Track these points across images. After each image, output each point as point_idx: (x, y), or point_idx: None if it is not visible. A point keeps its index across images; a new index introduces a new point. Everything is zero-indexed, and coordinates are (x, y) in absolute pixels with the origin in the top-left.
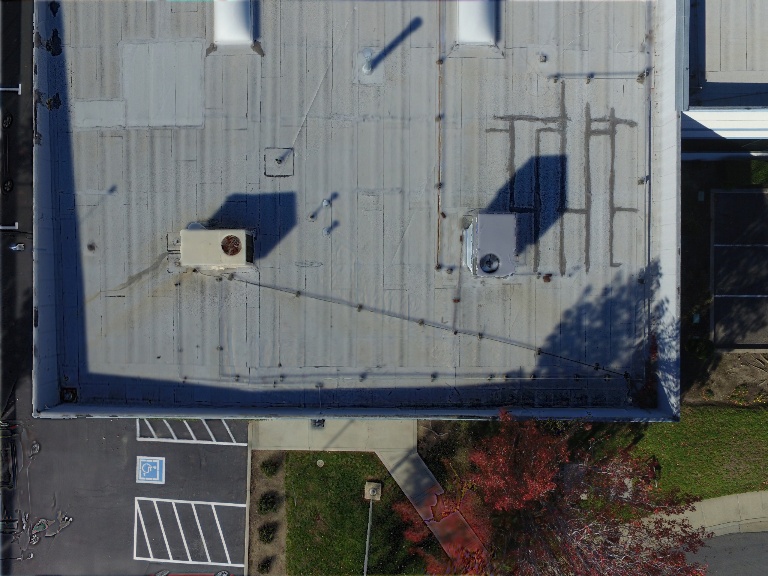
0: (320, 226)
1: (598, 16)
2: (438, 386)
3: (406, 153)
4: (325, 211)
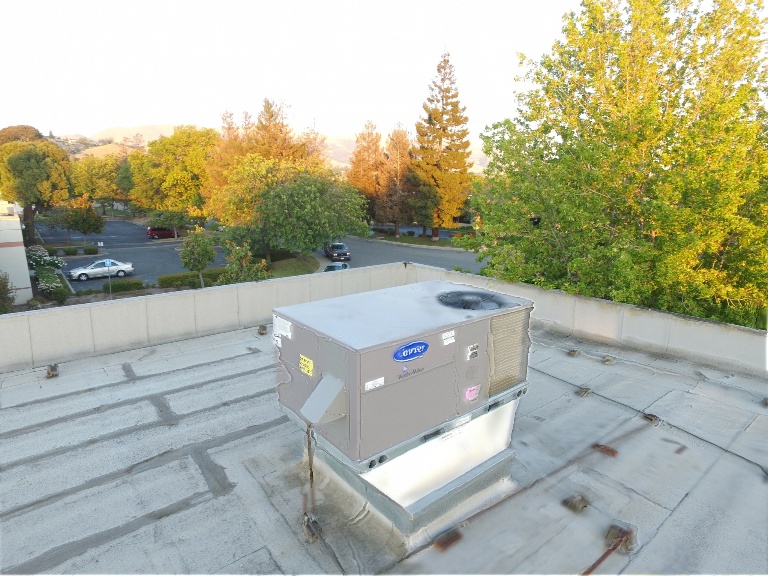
0: None
1: None
2: (758, 395)
3: None
4: None
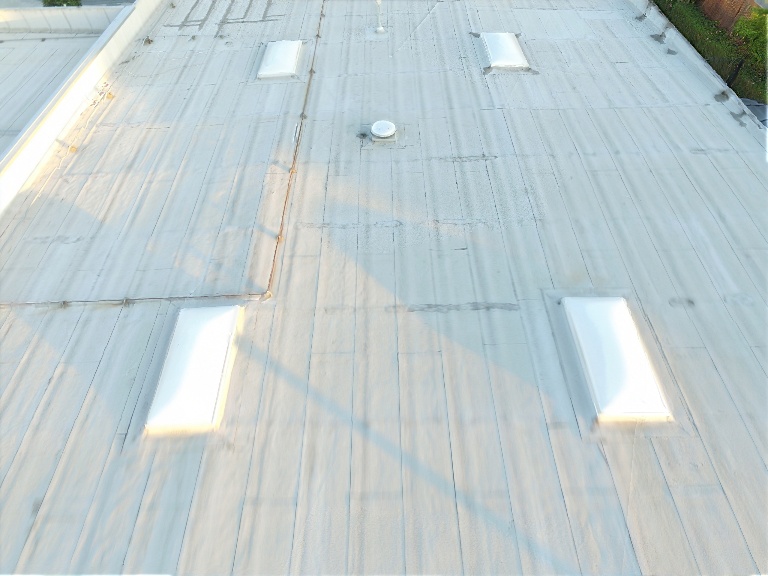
0: None
1: (171, 66)
2: None
3: (350, 4)
4: None
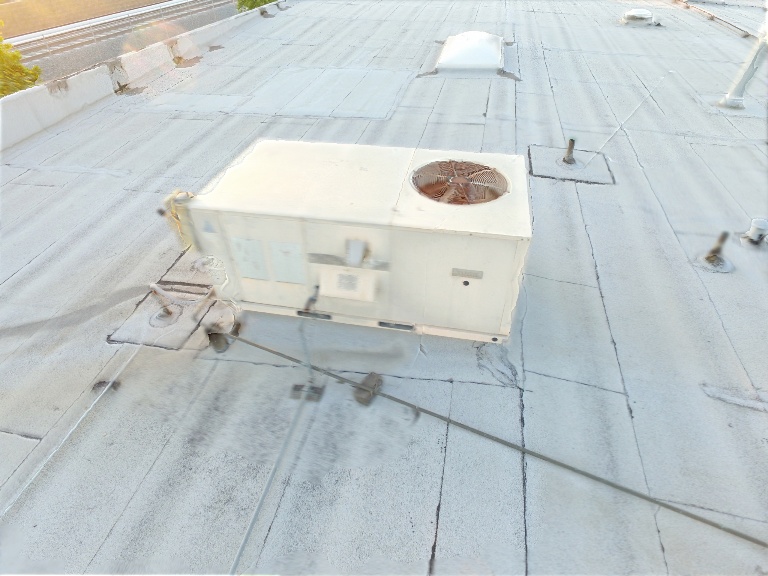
0: (760, 287)
1: None
2: None
3: None
4: (757, 256)
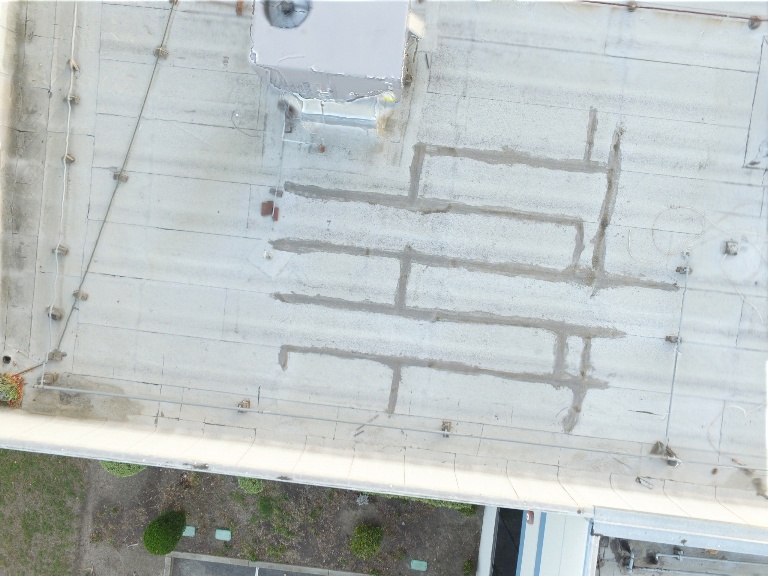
0: None
1: None
2: None
3: None
4: None
